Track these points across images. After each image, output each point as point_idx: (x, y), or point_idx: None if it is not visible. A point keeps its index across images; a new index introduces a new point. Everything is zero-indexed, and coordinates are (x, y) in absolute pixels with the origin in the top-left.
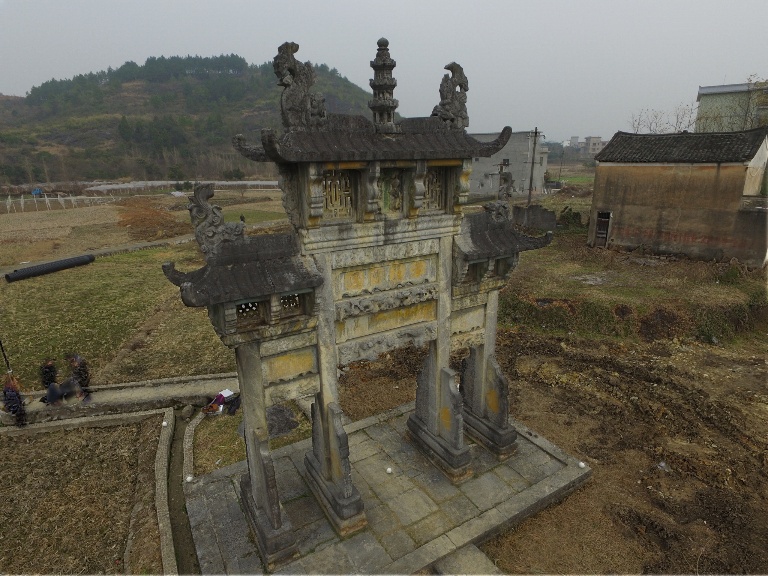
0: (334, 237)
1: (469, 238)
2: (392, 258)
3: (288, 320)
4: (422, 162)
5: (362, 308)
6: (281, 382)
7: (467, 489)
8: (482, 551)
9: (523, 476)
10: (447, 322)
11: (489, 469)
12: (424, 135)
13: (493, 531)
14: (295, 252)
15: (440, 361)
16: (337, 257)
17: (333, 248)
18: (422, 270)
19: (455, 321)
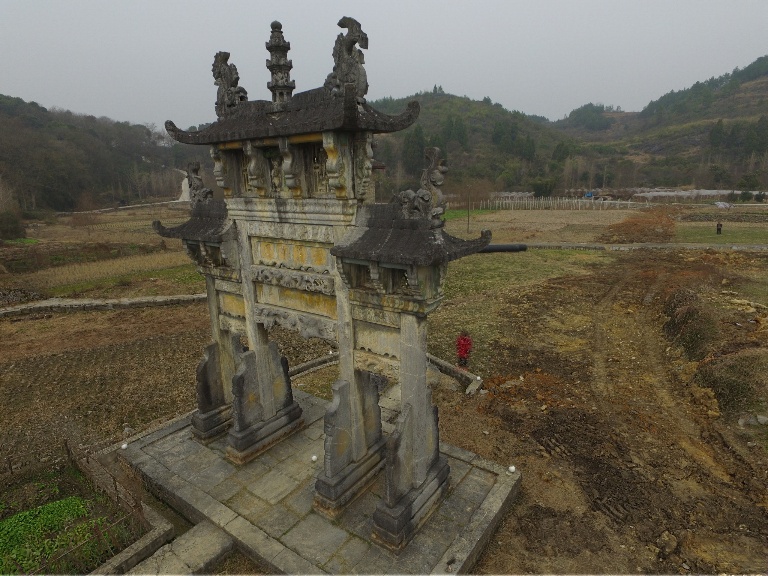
0: (243, 207)
1: (362, 232)
2: (290, 237)
3: (223, 267)
4: (283, 139)
5: (261, 276)
6: (229, 315)
7: (311, 520)
8: (235, 556)
9: (353, 567)
10: (347, 328)
11: (352, 532)
12: (308, 110)
13: (256, 556)
14: (226, 215)
15: (342, 370)
16: (250, 226)
17: (245, 217)
18: (323, 259)
19: (363, 333)
